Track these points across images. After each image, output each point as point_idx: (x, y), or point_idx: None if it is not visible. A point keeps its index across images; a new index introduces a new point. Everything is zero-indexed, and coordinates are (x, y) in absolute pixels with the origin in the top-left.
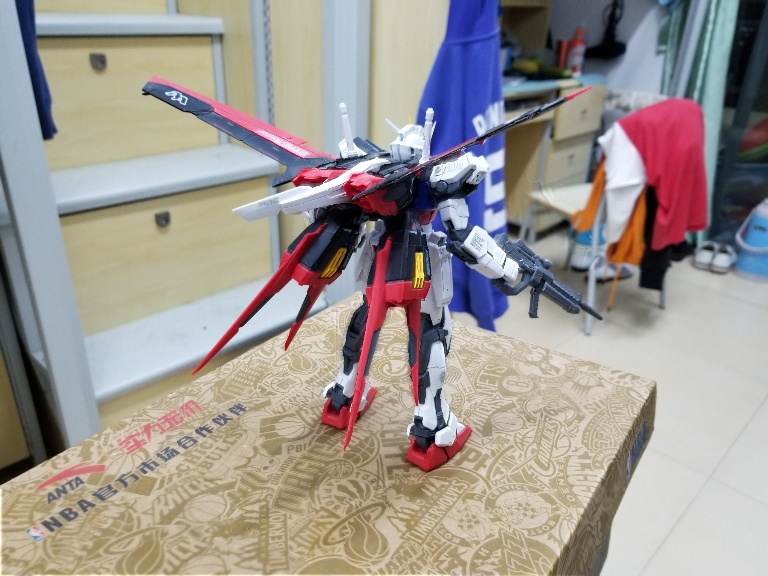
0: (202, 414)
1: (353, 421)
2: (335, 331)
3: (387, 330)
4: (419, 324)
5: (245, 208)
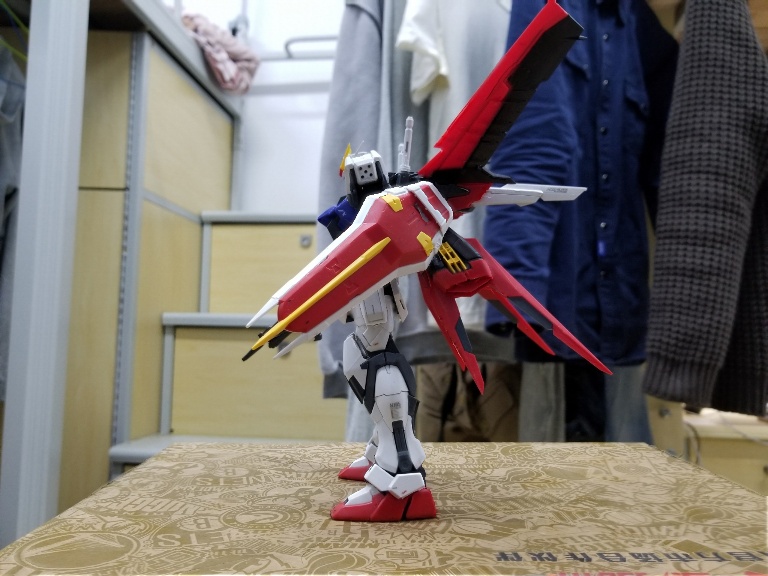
0: (565, 568)
1: (539, 342)
2: (183, 572)
3: (138, 542)
4: (435, 316)
5: (576, 189)
